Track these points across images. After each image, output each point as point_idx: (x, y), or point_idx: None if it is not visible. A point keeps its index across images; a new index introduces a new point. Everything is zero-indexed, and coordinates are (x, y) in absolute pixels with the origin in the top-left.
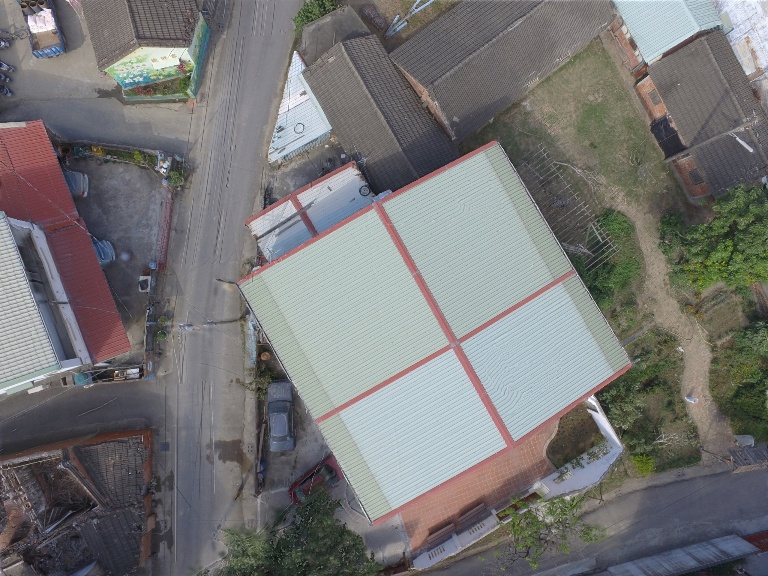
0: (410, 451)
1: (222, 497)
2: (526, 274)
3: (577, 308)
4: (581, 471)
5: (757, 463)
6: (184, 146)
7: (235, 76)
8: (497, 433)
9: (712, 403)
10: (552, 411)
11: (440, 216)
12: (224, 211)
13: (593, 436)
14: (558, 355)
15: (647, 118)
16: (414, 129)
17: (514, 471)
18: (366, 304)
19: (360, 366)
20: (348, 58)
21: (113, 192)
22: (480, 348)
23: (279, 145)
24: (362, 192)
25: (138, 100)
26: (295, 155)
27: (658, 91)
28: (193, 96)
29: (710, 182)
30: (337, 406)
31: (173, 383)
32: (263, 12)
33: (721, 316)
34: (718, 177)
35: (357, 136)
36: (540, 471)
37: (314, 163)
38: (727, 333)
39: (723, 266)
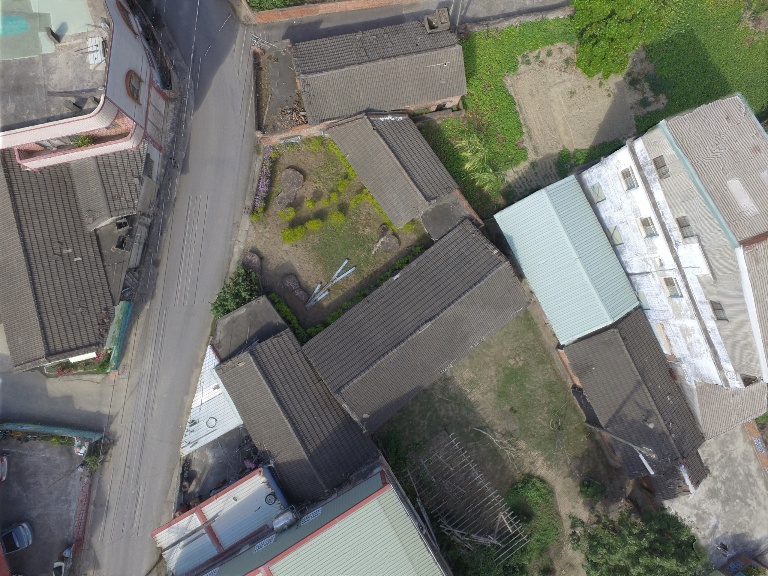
0: None
1: None
2: None
3: None
4: None
5: None
6: (105, 419)
7: (157, 347)
8: None
9: None
10: None
11: (328, 573)
12: (143, 484)
13: None
14: None
15: (569, 380)
16: (323, 428)
17: None
18: None
19: None
20: (256, 367)
21: (33, 469)
22: None
23: (191, 439)
24: (268, 500)
25: None
26: None
27: (574, 370)
28: (115, 370)
29: (625, 463)
30: None
31: None
32: (186, 282)
33: None
34: (632, 460)
35: (267, 436)
36: None
37: (233, 434)
38: None
39: None
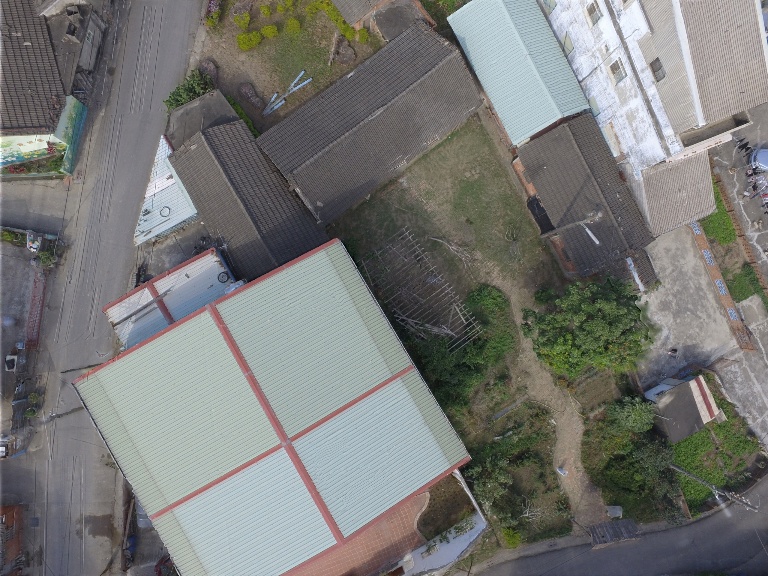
0: (241, 547)
1: (91, 572)
2: (363, 370)
3: (415, 403)
4: (445, 546)
5: (613, 541)
6: (59, 223)
7: (112, 153)
8: (327, 530)
9: (584, 474)
10: (385, 506)
11: (275, 316)
12: (98, 287)
13: (465, 508)
14: (381, 457)
15: (524, 194)
16: (277, 214)
17: (385, 543)
18: (199, 403)
19: (193, 464)
20: (208, 147)
21: None
22: (312, 446)
23: (145, 228)
24: (220, 279)
25: (14, 177)
26: (170, 232)
27: (527, 172)
28: (69, 174)
29: (576, 262)
30: (170, 503)
31: (43, 459)
32: (142, 90)
33: (594, 388)
34: (583, 258)
35: (220, 221)
36: (411, 543)
37: (190, 240)
38: (600, 405)
39: (566, 357)
